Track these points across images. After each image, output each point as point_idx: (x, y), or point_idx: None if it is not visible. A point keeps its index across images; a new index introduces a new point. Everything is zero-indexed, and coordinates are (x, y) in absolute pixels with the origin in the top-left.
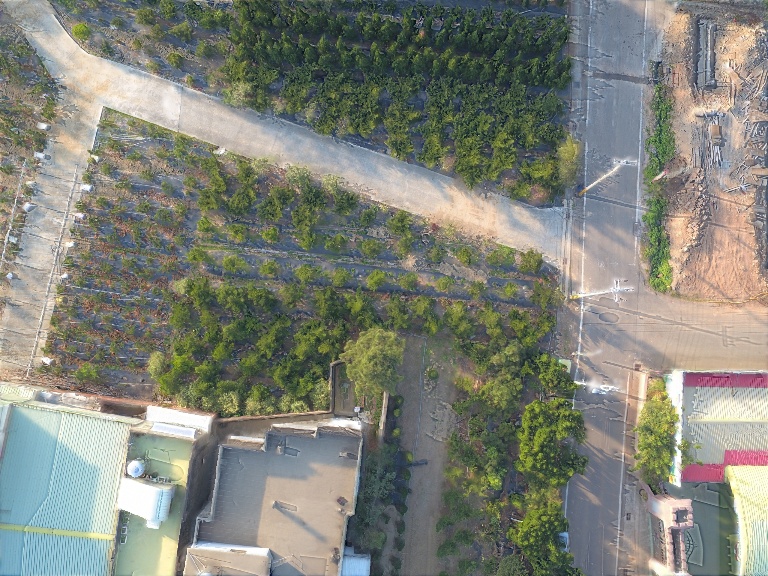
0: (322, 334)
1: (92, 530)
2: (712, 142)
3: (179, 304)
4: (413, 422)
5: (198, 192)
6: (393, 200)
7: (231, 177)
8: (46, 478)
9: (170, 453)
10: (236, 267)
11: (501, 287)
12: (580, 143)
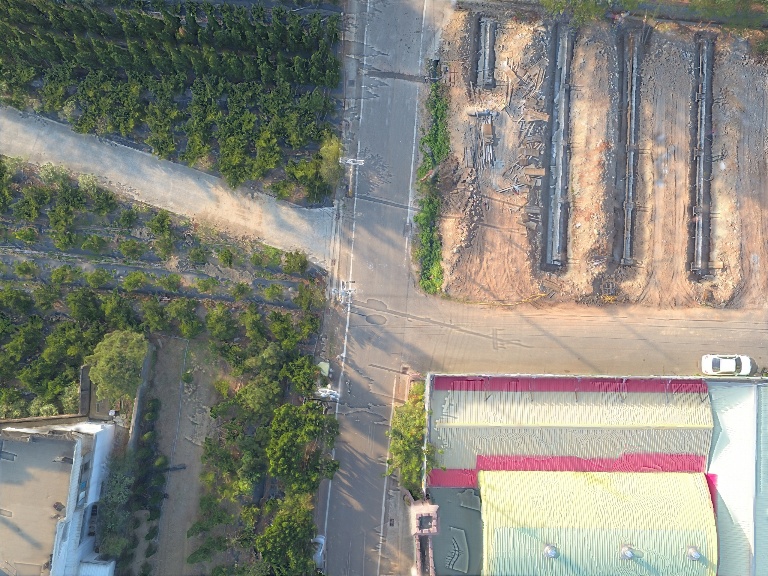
0: (71, 336)
1: None
2: (484, 142)
3: None
4: (172, 426)
5: None
6: (157, 200)
7: None
8: None
9: None
10: None
11: None
12: (353, 142)
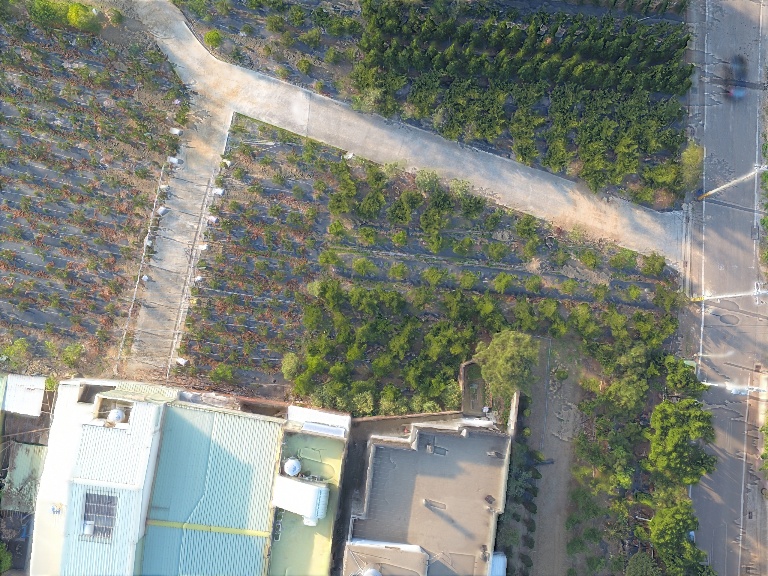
0: (454, 336)
1: (248, 527)
2: None
3: (311, 306)
4: (539, 422)
5: (329, 196)
6: (517, 204)
7: (359, 181)
8: (202, 476)
9: (321, 452)
10: (365, 270)
11: (623, 289)
12: (698, 148)
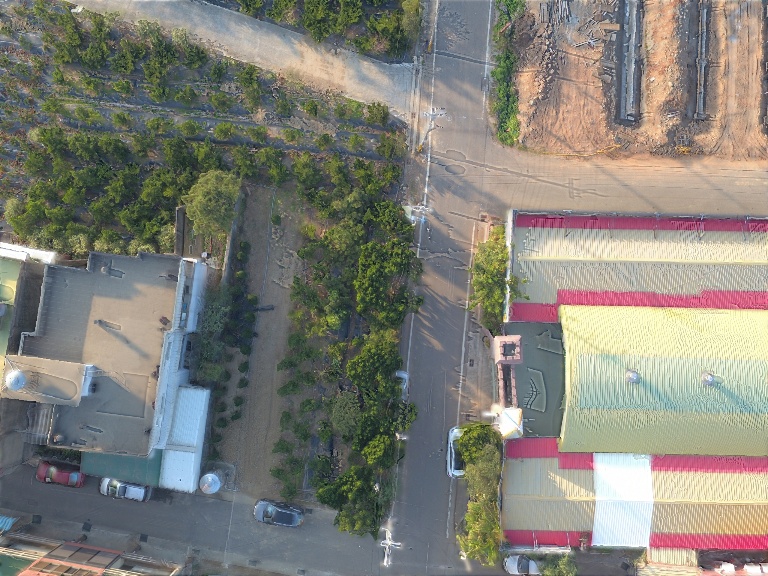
0: (167, 179)
1: None
2: None
3: (35, 154)
4: (260, 269)
5: (54, 46)
6: (245, 56)
7: (88, 34)
8: None
9: (2, 274)
10: (91, 119)
11: None
12: (431, 1)
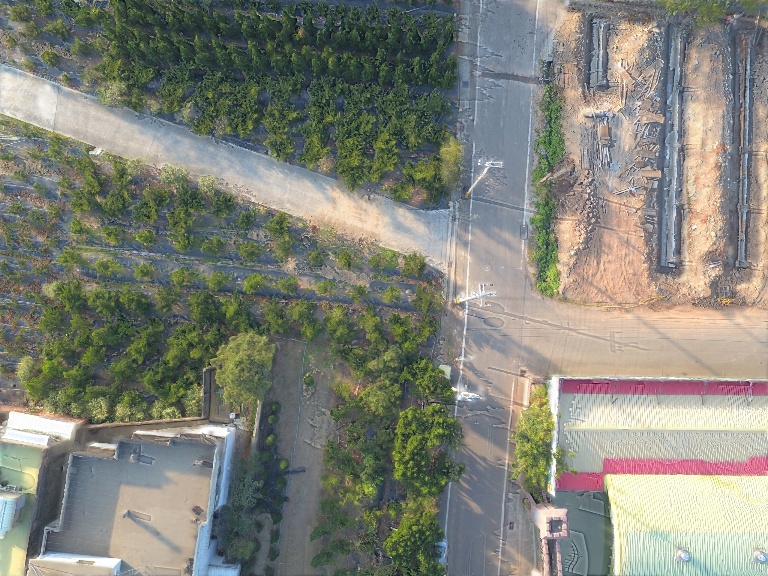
0: (194, 339)
1: None
2: (601, 143)
3: (51, 307)
4: (291, 429)
5: None
6: (274, 202)
7: (107, 178)
8: None
9: (21, 461)
10: (111, 270)
11: (384, 291)
12: (467, 144)
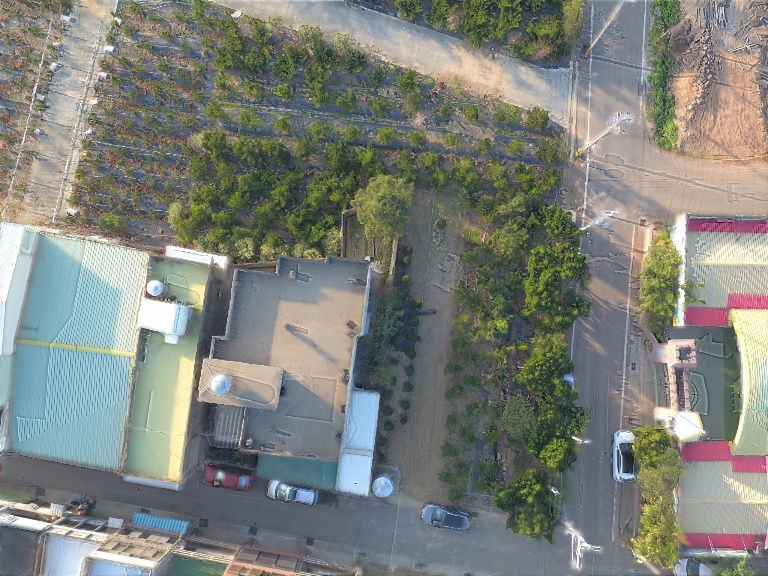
0: (334, 183)
1: (113, 348)
2: (717, 3)
3: (197, 158)
4: (422, 273)
5: (215, 51)
6: (403, 61)
7: (247, 39)
8: (70, 300)
9: (187, 278)
10: (251, 124)
11: (508, 144)
12: (586, 7)
